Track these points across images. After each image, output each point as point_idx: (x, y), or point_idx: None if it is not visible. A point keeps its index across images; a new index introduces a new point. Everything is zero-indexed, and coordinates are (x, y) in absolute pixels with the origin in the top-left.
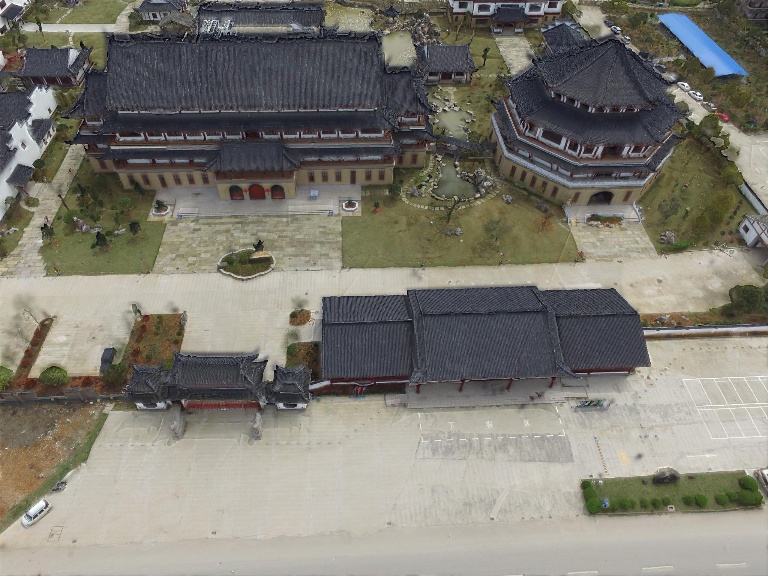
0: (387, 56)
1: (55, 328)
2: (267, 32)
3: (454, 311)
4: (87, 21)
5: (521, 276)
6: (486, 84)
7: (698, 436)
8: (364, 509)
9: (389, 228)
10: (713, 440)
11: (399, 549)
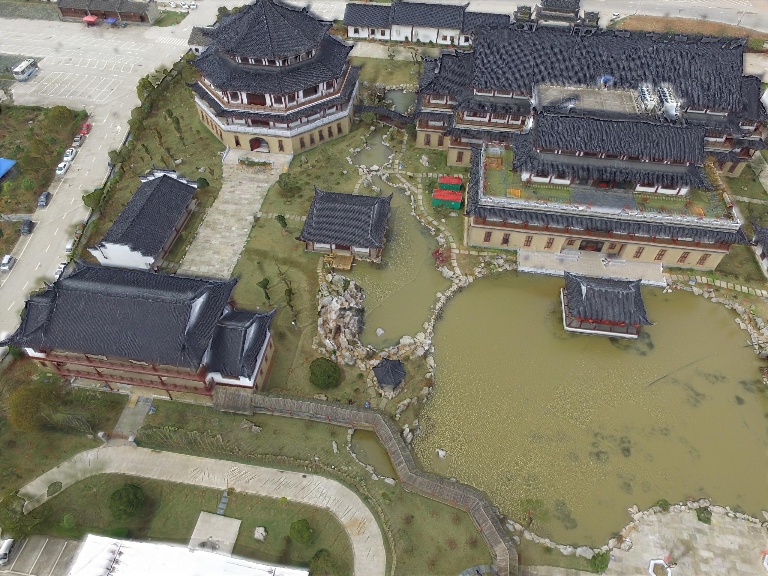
0: (417, 293)
1: None
2: (601, 112)
3: (442, 9)
4: None
5: (383, 54)
6: (304, 201)
7: (342, 6)
8: (488, 7)
9: None
10: (336, 5)
11: (476, 0)
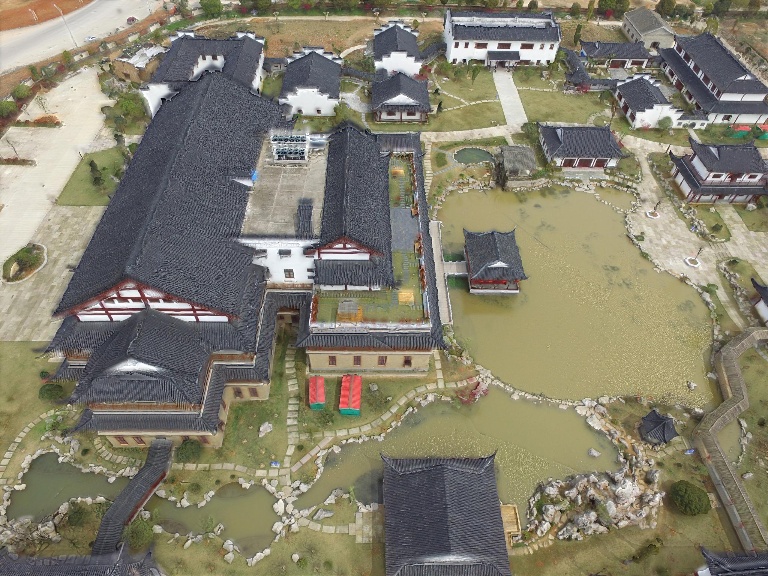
0: (512, 424)
1: (22, 167)
2: (306, 194)
3: None
4: (529, 104)
5: None
6: None
7: None
8: None
9: (4, 390)
10: None
11: None
